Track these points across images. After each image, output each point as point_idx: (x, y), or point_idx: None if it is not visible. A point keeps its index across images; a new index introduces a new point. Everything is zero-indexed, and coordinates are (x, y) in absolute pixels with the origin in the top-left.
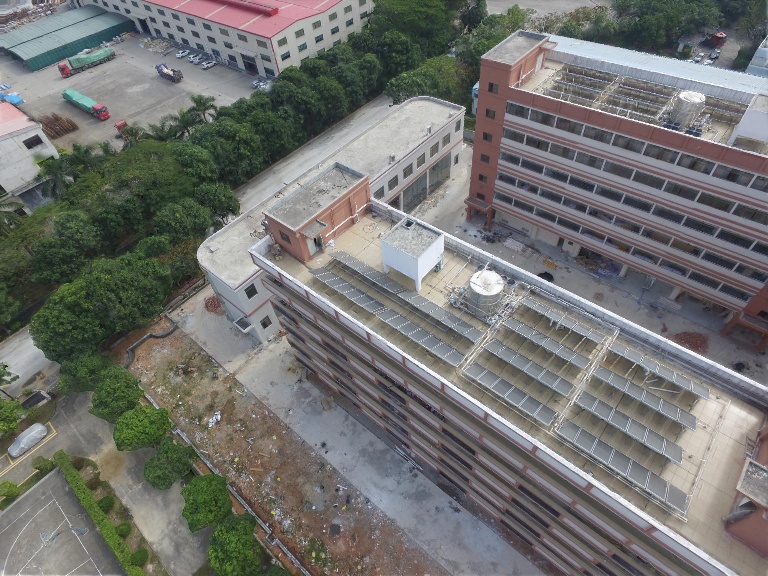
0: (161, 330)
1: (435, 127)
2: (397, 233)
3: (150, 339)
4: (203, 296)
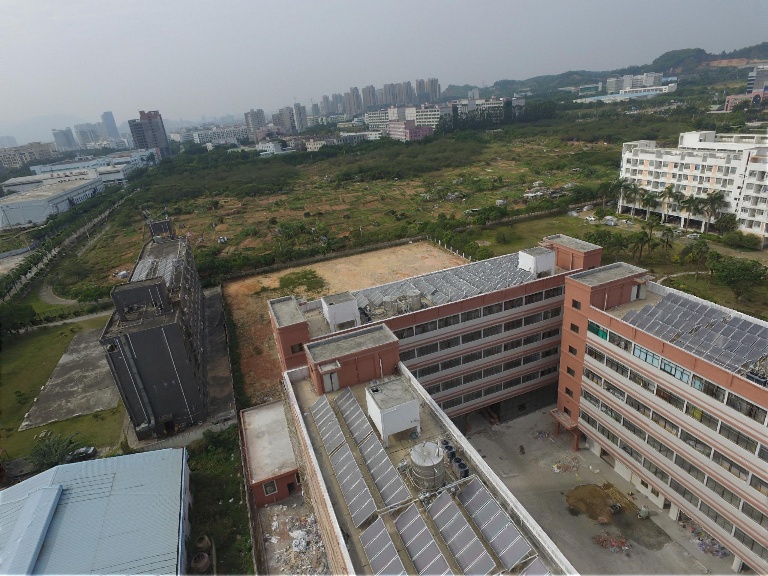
0: None
1: None
2: None
3: None
4: None
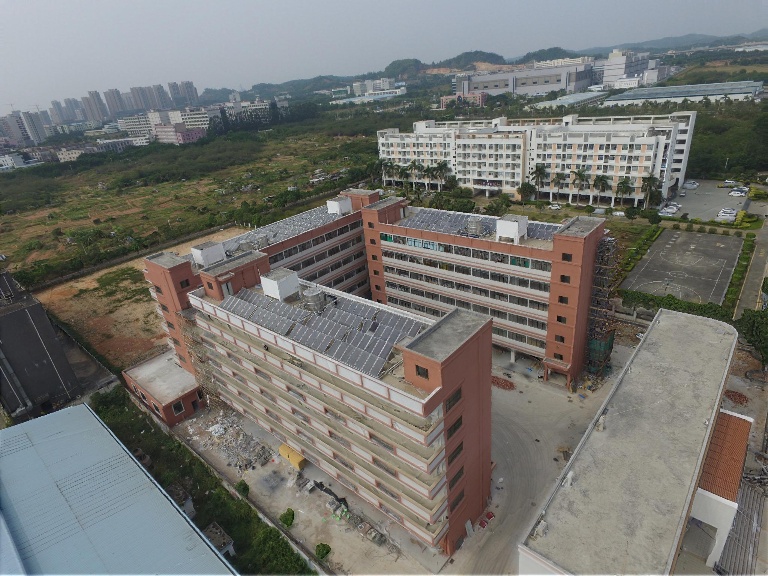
0: (760, 376)
1: (565, 501)
2: (521, 219)
3: (761, 369)
4: (758, 402)
